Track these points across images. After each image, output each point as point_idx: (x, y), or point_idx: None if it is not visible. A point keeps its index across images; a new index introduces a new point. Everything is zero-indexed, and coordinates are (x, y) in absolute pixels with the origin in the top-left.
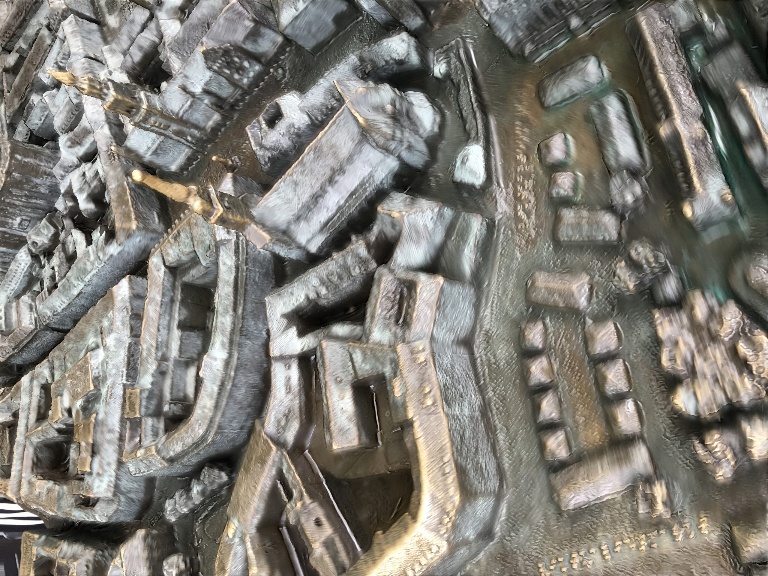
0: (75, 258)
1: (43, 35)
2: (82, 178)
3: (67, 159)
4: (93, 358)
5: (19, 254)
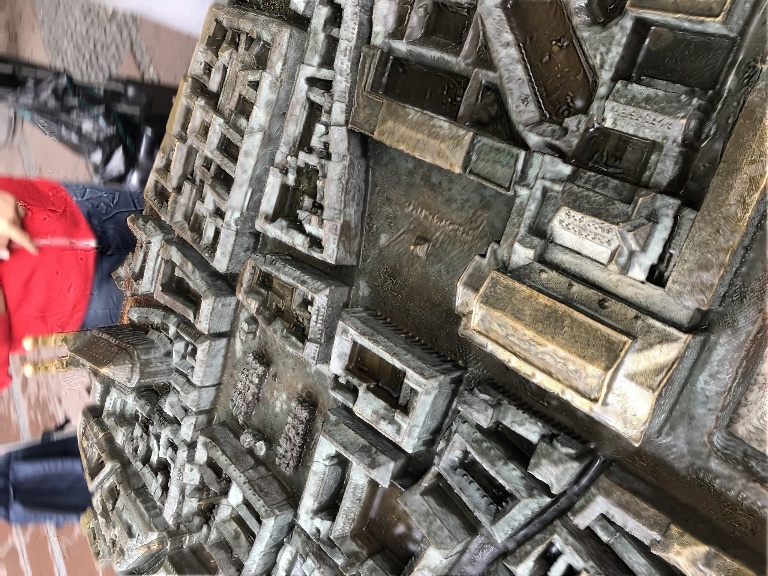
0: (151, 449)
1: (190, 314)
2: (168, 437)
3: (167, 412)
4: (131, 541)
5: (129, 397)
